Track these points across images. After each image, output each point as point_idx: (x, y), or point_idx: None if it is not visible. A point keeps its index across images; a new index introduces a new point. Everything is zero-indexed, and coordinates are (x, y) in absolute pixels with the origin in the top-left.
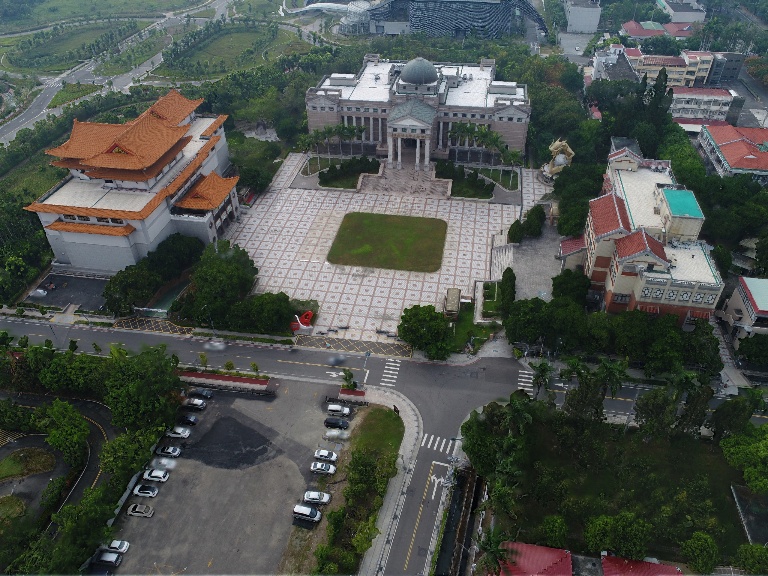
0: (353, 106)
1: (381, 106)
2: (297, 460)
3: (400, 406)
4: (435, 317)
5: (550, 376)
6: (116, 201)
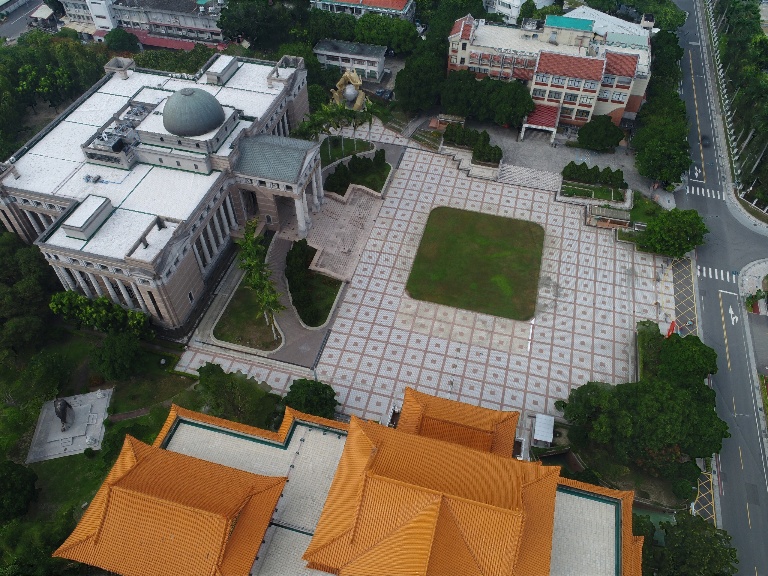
0: (197, 219)
1: (218, 186)
2: None
3: (759, 271)
4: (684, 213)
5: (688, 178)
6: (571, 567)
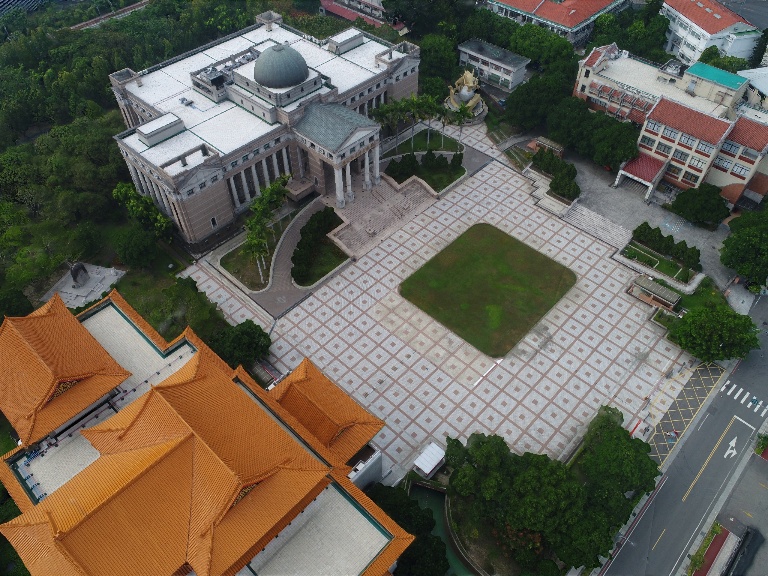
0: (239, 157)
1: (273, 136)
2: None
3: None
4: (732, 315)
5: None
6: (306, 567)
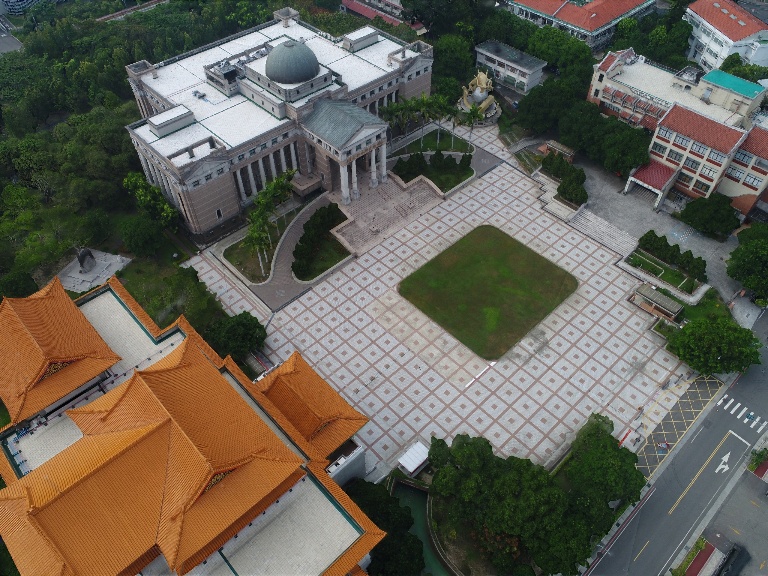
0: (246, 151)
1: (281, 131)
2: None
3: None
4: (732, 328)
5: None
6: (276, 557)
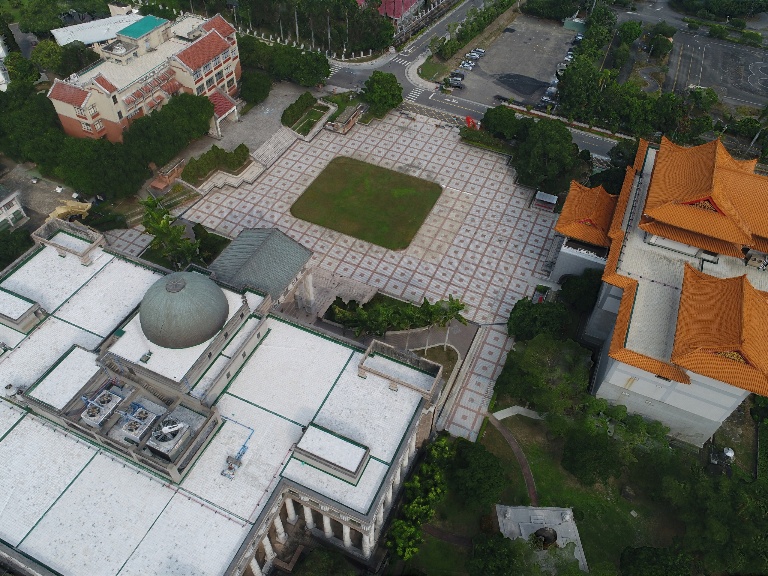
0: None
1: None
2: (482, 71)
3: (416, 78)
4: None
5: None
6: None
